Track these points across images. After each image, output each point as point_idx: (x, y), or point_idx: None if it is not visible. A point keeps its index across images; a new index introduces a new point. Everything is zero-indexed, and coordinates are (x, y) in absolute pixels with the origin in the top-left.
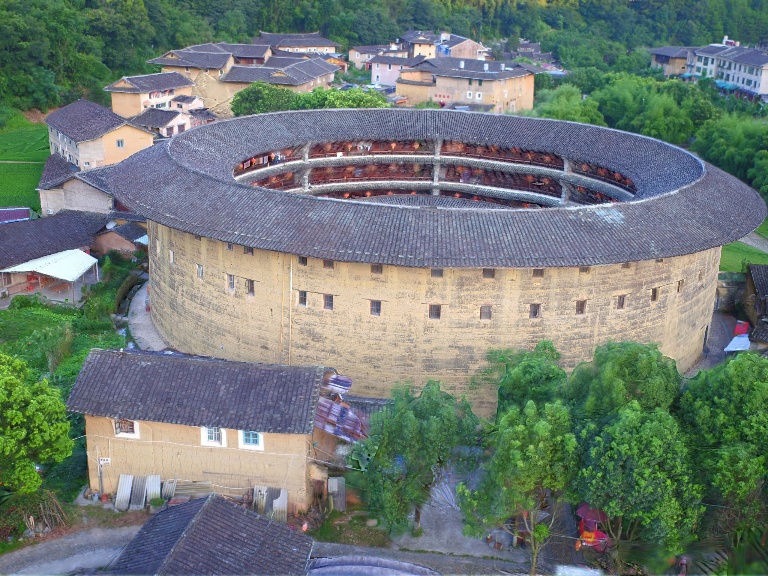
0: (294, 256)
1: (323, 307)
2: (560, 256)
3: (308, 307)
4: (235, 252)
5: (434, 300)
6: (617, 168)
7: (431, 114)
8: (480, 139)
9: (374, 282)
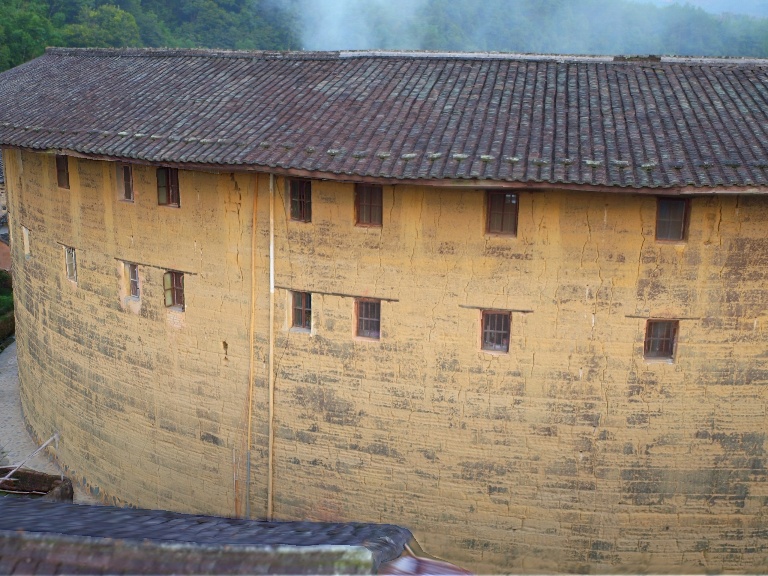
0: (278, 199)
1: (354, 333)
2: None
3: (315, 333)
4: (138, 204)
5: (660, 306)
6: None
7: None
8: None
9: (493, 259)
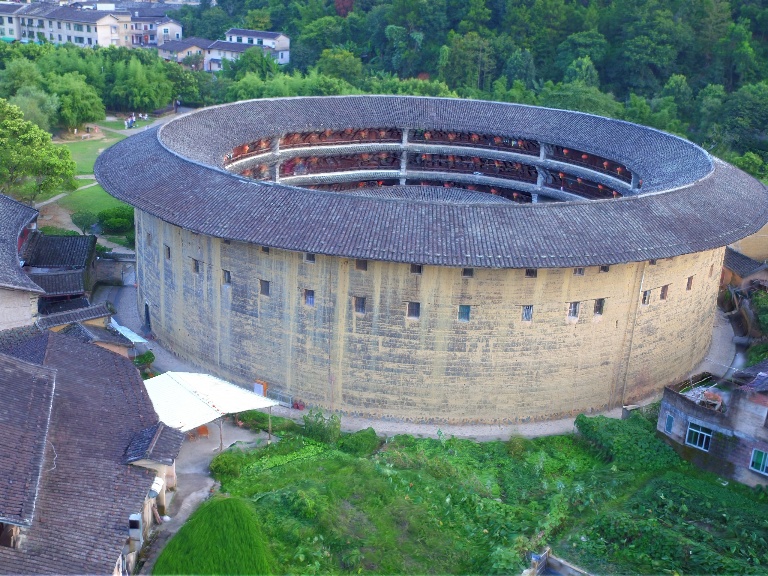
0: None
1: None
2: (767, 197)
3: (650, 305)
4: (587, 275)
5: None
6: (485, 130)
7: (246, 107)
8: (316, 126)
9: (693, 260)
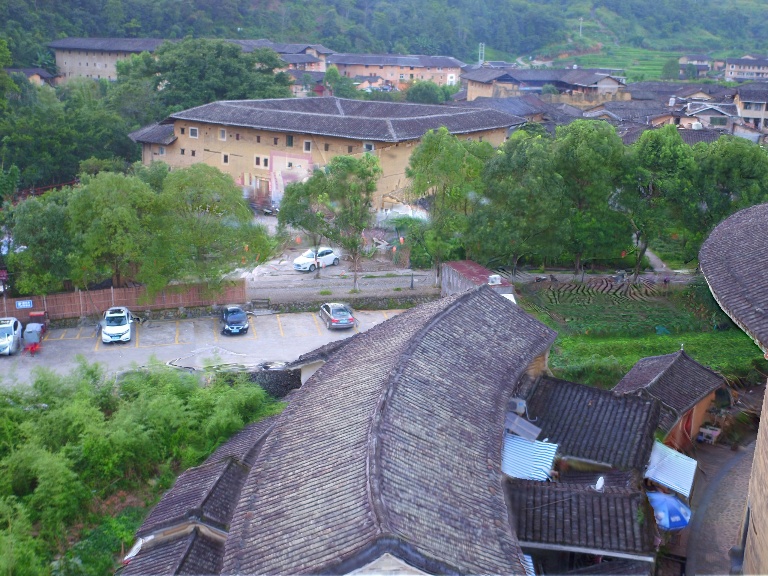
0: None
1: None
2: None
3: None
4: None
5: None
6: None
7: None
8: None
9: None
